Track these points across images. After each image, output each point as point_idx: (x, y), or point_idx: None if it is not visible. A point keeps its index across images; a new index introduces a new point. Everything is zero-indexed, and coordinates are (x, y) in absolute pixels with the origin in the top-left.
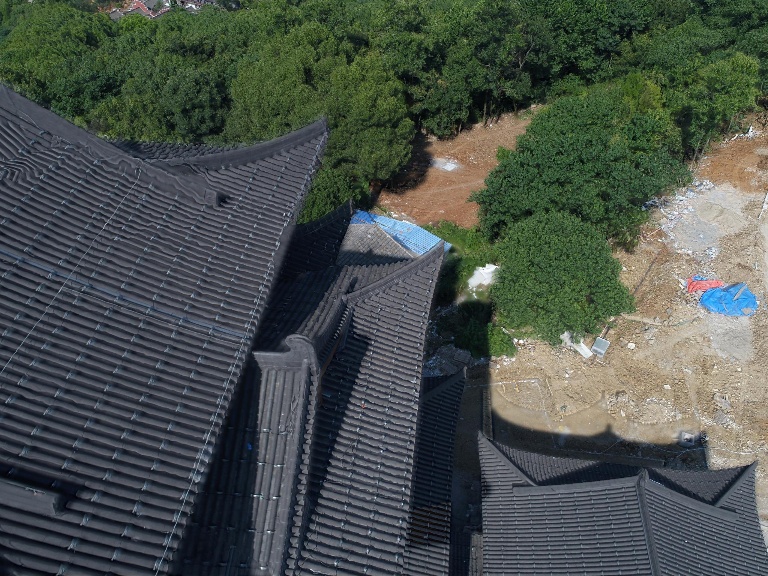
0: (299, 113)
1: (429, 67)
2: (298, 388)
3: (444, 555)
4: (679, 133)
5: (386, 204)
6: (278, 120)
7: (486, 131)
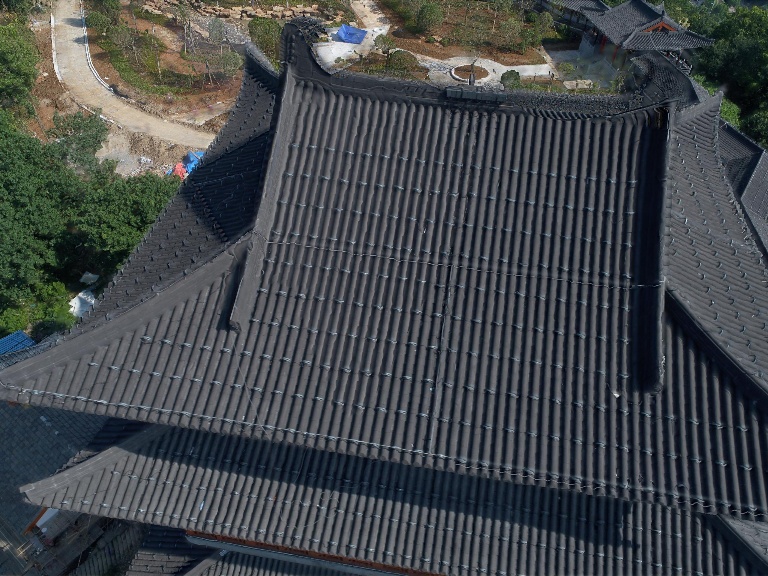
0: None
1: None
2: None
3: None
4: None
5: None
6: None
7: None
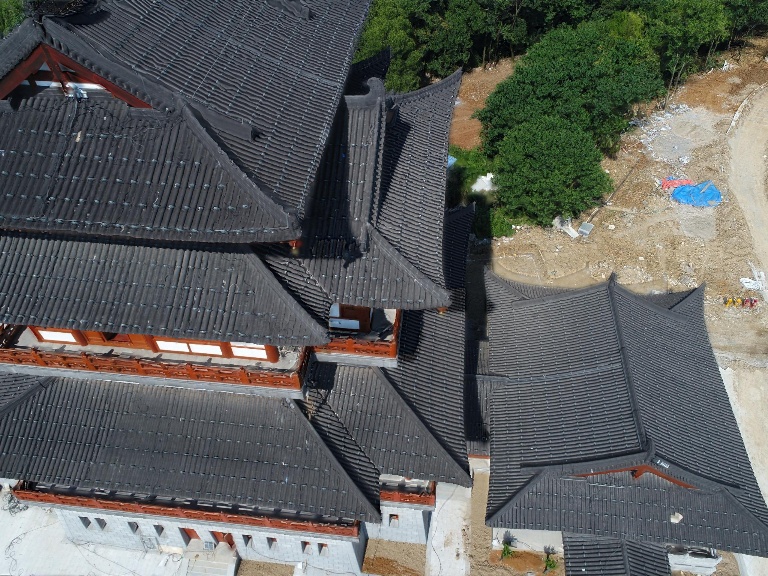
0: None
1: (433, 11)
2: (374, 119)
3: (461, 317)
4: (658, 59)
5: None
6: None
7: (485, 74)
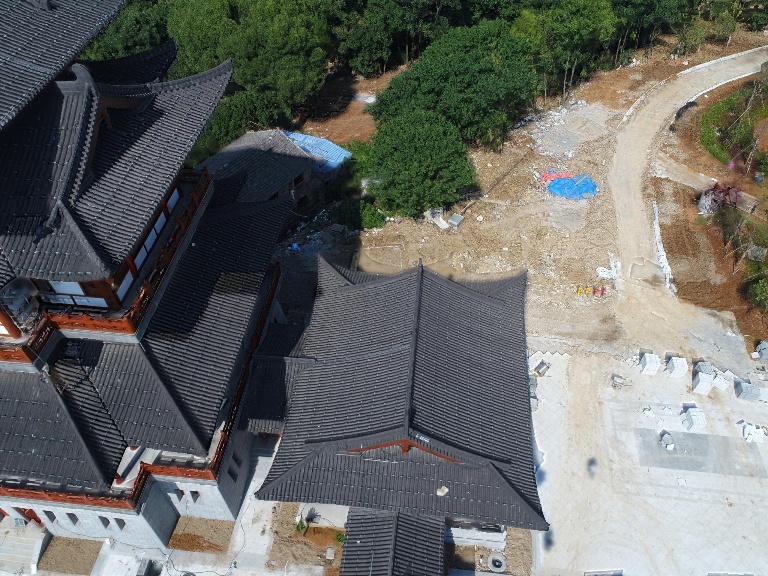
0: (223, 44)
1: (351, 9)
2: None
3: (252, 300)
4: (552, 56)
5: (309, 130)
6: (208, 53)
7: None
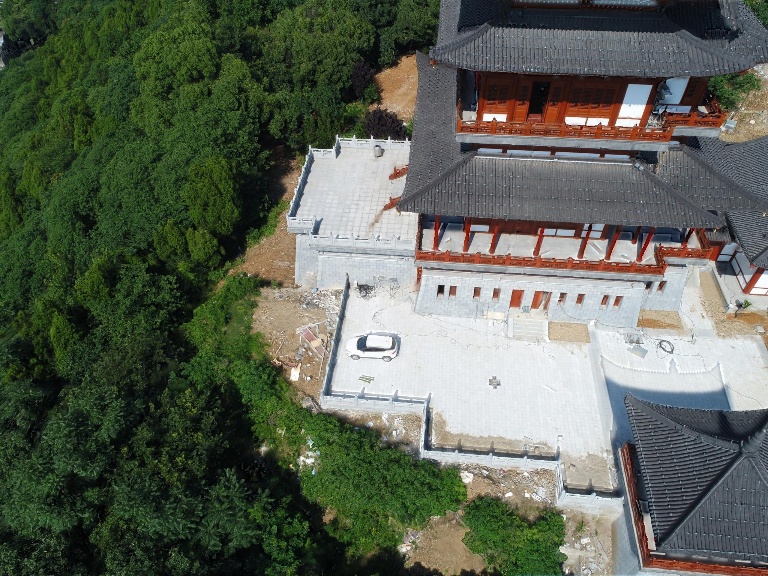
0: None
1: None
2: None
3: None
4: None
5: None
6: None
7: None
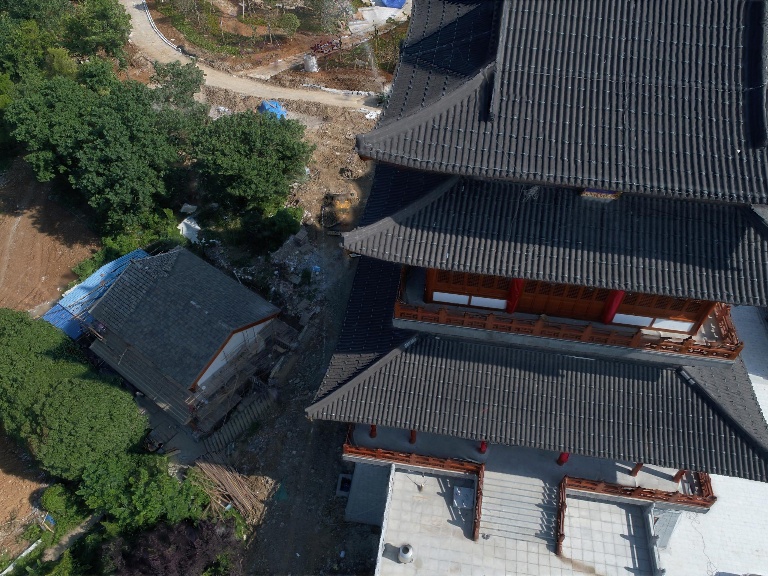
0: None
1: None
2: None
3: None
4: None
5: None
6: None
7: None
